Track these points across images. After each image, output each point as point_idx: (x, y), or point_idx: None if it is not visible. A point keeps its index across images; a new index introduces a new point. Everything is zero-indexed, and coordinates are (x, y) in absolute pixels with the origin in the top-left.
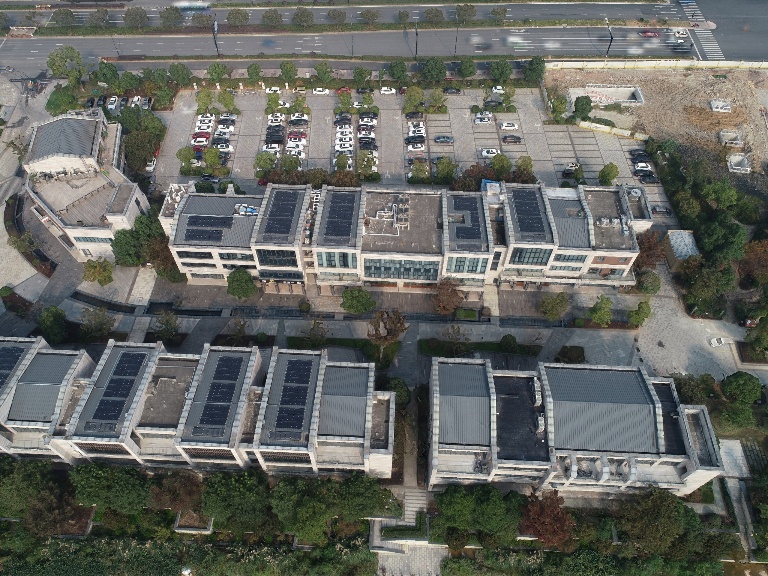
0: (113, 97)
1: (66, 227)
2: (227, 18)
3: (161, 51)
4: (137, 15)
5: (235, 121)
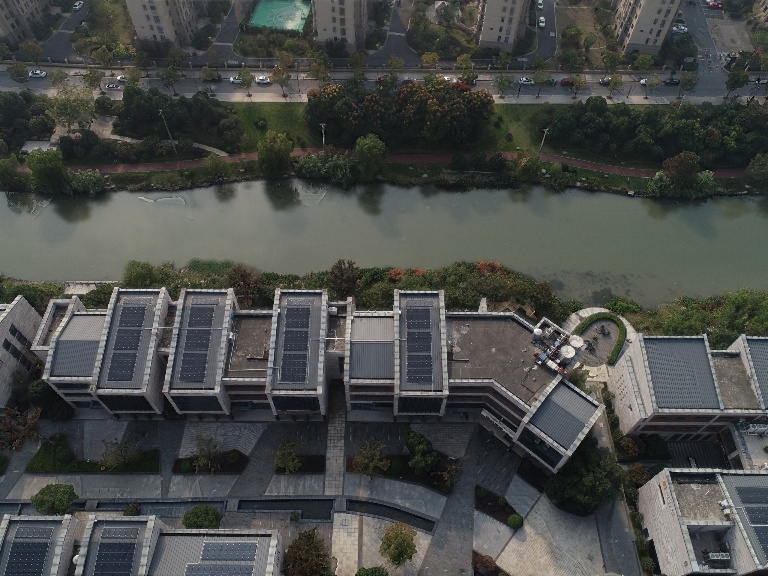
0: None
1: None
2: None
3: None
4: None
5: None
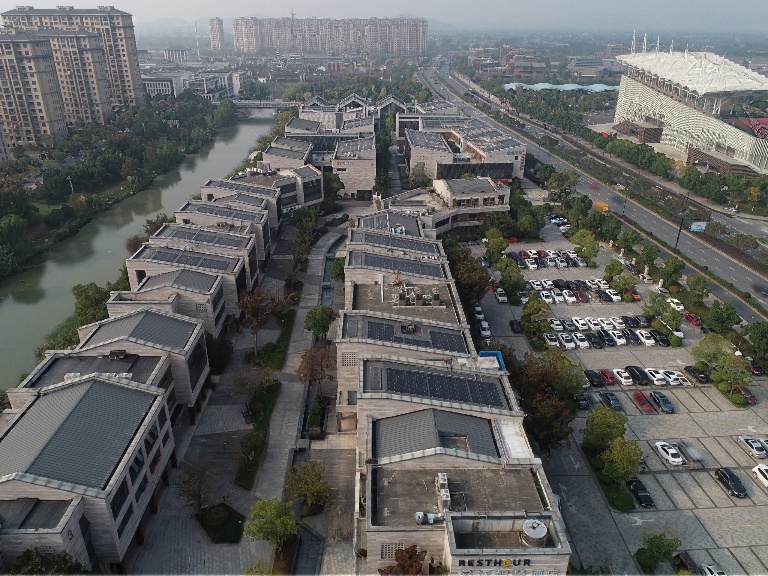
0: (564, 219)
1: (382, 200)
2: (734, 237)
3: (654, 230)
4: (677, 203)
5: (579, 267)
